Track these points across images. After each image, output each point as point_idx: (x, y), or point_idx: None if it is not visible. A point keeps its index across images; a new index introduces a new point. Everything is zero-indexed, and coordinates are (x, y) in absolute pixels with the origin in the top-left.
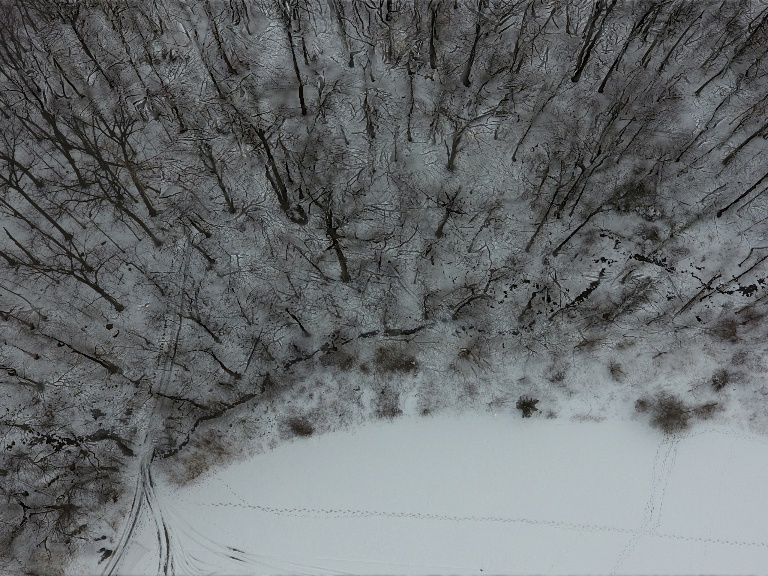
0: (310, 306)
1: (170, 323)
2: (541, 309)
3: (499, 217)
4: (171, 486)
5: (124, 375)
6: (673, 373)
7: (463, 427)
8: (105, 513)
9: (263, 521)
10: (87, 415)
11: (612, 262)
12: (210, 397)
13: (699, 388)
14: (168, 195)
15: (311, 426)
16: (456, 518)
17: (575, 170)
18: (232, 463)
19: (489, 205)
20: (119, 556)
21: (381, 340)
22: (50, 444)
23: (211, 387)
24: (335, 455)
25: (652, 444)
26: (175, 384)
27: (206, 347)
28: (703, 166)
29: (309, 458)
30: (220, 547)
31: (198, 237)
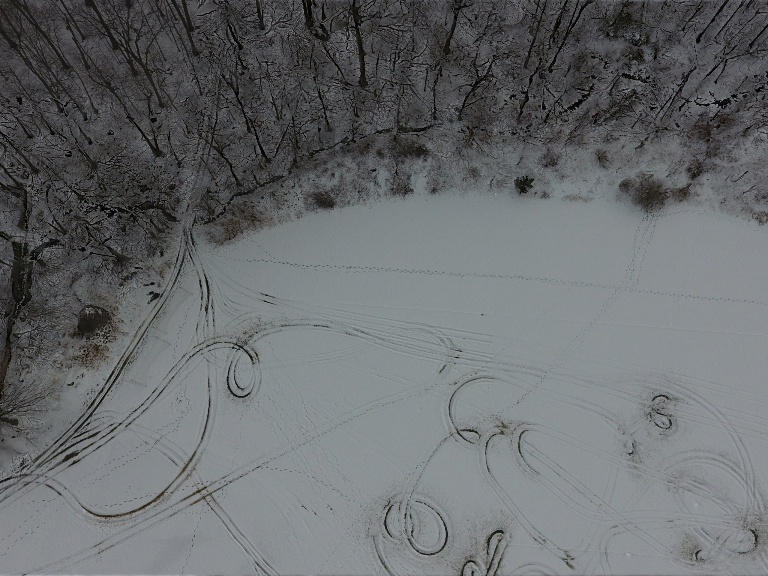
0: (332, 106)
1: (207, 118)
2: (537, 114)
3: (501, 39)
4: (210, 245)
5: (167, 158)
6: (653, 162)
7: (467, 204)
8: (153, 264)
9: (291, 274)
10: (135, 189)
11: (601, 79)
12: (244, 176)
13: (676, 174)
14: (204, 13)
15: (333, 200)
16: (460, 274)
17: (569, 2)
18: (264, 228)
19: (492, 28)
20: (166, 298)
21: (395, 135)
22: (103, 211)
23: (244, 169)
24: (354, 224)
25: (634, 220)
26: (213, 165)
27: (240, 136)
28: (685, 1)
29: (331, 226)
30: (254, 293)
31: (231, 49)
